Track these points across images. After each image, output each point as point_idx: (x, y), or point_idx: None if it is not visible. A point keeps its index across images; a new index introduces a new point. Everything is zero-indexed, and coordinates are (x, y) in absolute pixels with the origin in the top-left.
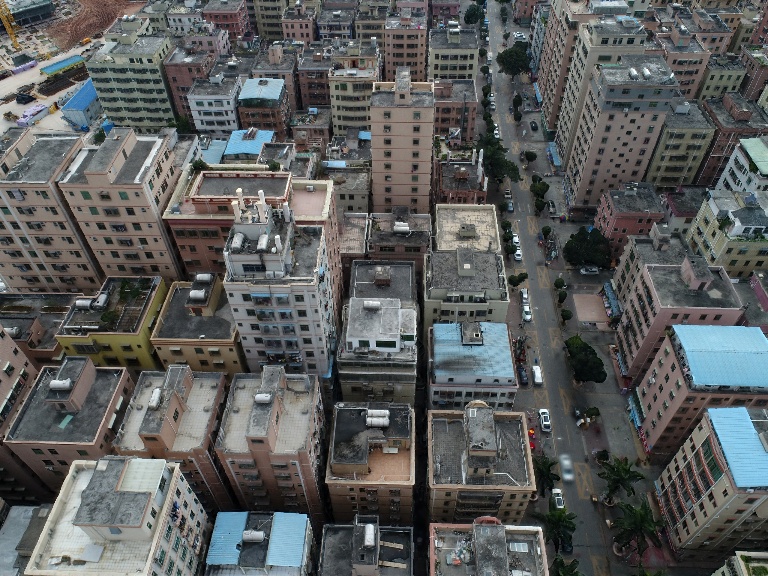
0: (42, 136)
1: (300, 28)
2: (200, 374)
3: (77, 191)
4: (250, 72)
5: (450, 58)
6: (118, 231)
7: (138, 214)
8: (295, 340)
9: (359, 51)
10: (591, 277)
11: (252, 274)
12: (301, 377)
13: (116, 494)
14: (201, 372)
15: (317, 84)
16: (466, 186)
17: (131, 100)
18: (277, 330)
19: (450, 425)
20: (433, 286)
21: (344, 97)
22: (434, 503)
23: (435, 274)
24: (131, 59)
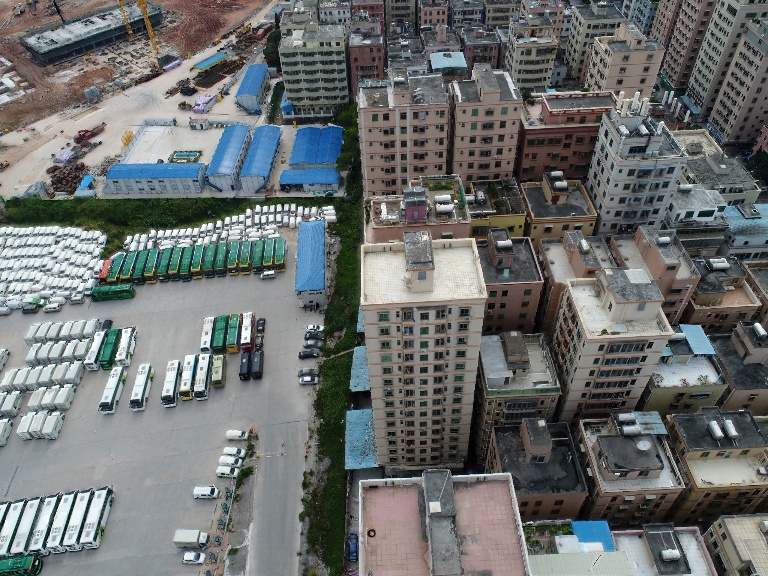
0: (409, 76)
1: (437, 15)
2: (585, 238)
3: (470, 109)
4: None
5: (600, 27)
6: (485, 143)
7: (508, 127)
8: (649, 210)
9: (539, 22)
10: (761, 194)
11: (633, 155)
12: (671, 231)
13: (632, 286)
14: (586, 236)
15: (481, 57)
16: (666, 120)
17: (313, 81)
18: (638, 202)
19: (760, 271)
20: (701, 182)
21: (527, 61)
22: (763, 326)
23: (697, 174)
24: (321, 43)
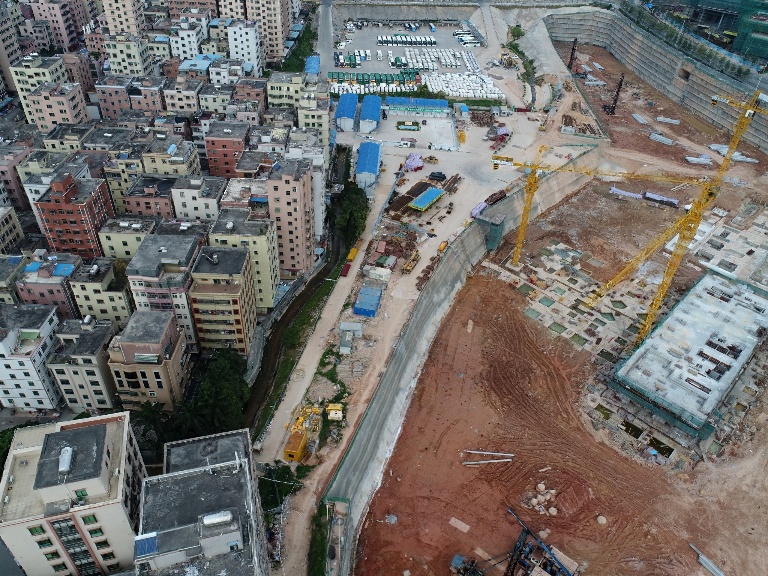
0: None
1: None
2: None
3: None
4: (205, 87)
5: None
6: None
7: None
8: None
9: None
10: None
11: None
12: None
13: None
14: None
15: None
16: None
17: None
18: None
19: None
20: None
21: None
22: None
23: None
24: None
